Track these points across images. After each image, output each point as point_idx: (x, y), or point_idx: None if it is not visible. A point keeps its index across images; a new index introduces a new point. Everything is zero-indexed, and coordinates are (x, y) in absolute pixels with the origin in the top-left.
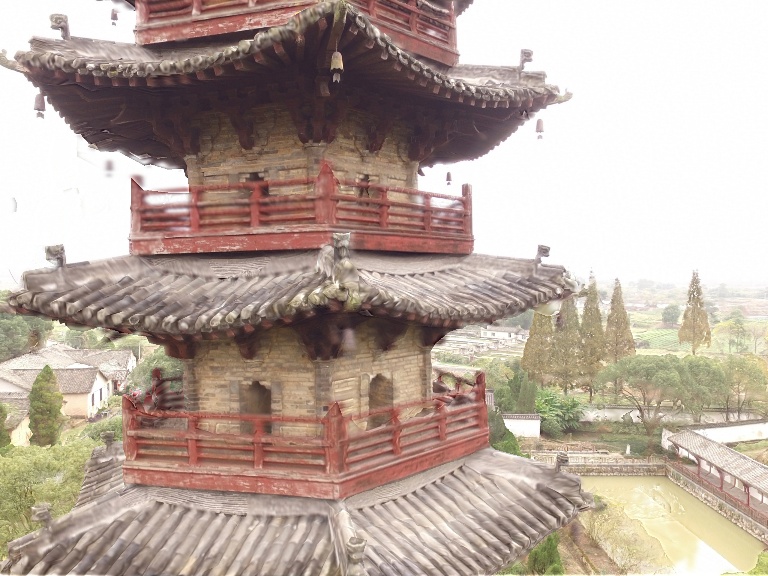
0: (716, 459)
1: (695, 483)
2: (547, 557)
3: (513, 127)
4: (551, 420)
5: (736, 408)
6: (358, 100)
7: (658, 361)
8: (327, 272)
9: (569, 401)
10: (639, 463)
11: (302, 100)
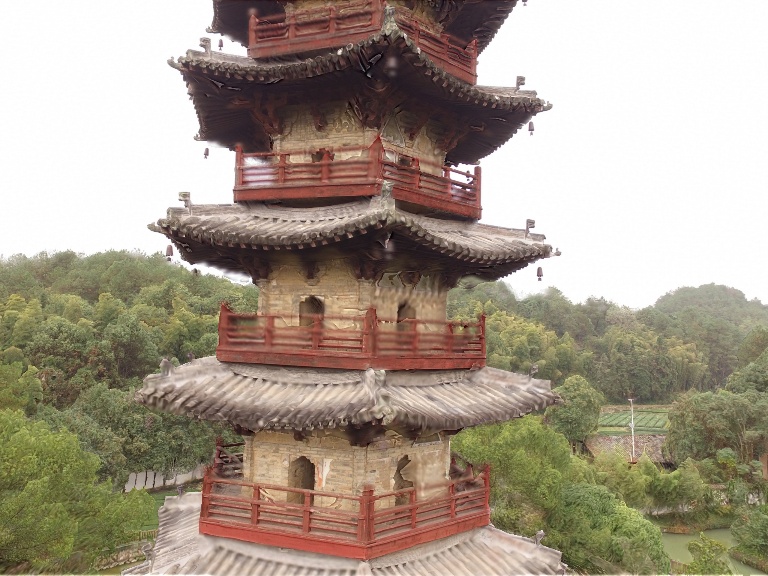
0: None
1: None
2: None
3: (234, 40)
4: None
5: None
6: None
7: None
8: None
9: None
10: None
11: None
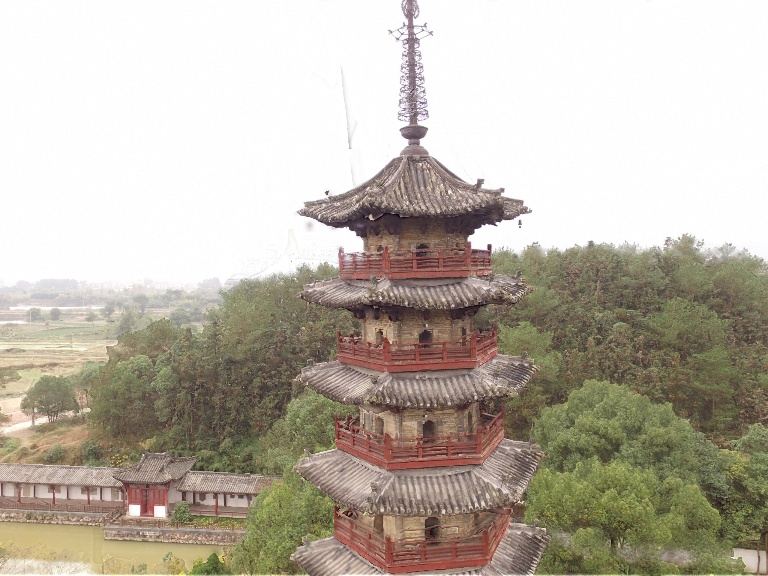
0: (15, 477)
1: None
2: None
3: None
4: None
5: None
6: None
7: None
8: (515, 363)
9: None
10: None
11: None
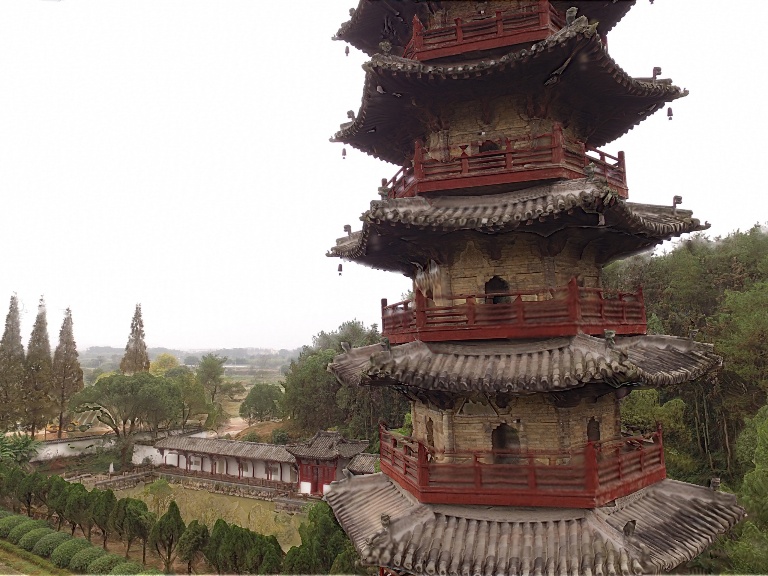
0: (209, 449)
1: (189, 477)
2: (175, 522)
3: None
4: (10, 460)
5: (181, 422)
6: (603, 15)
7: (140, 377)
8: None
9: (20, 440)
10: (130, 475)
11: (595, 1)
